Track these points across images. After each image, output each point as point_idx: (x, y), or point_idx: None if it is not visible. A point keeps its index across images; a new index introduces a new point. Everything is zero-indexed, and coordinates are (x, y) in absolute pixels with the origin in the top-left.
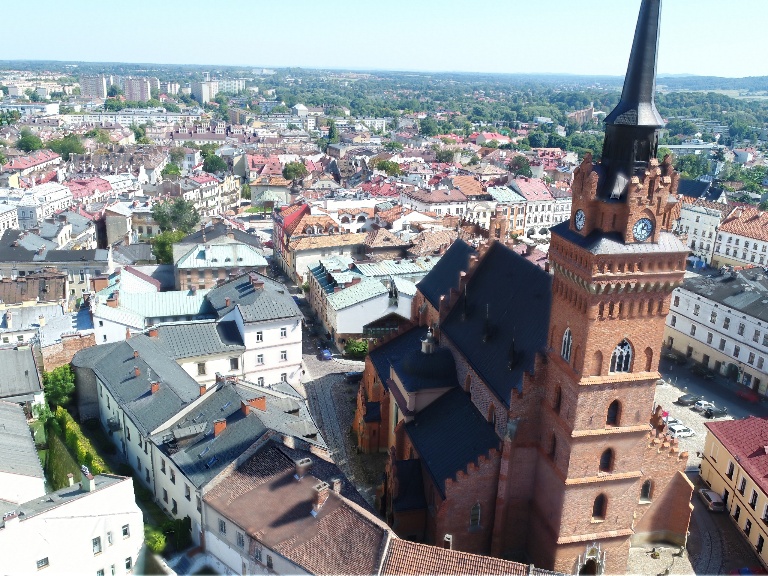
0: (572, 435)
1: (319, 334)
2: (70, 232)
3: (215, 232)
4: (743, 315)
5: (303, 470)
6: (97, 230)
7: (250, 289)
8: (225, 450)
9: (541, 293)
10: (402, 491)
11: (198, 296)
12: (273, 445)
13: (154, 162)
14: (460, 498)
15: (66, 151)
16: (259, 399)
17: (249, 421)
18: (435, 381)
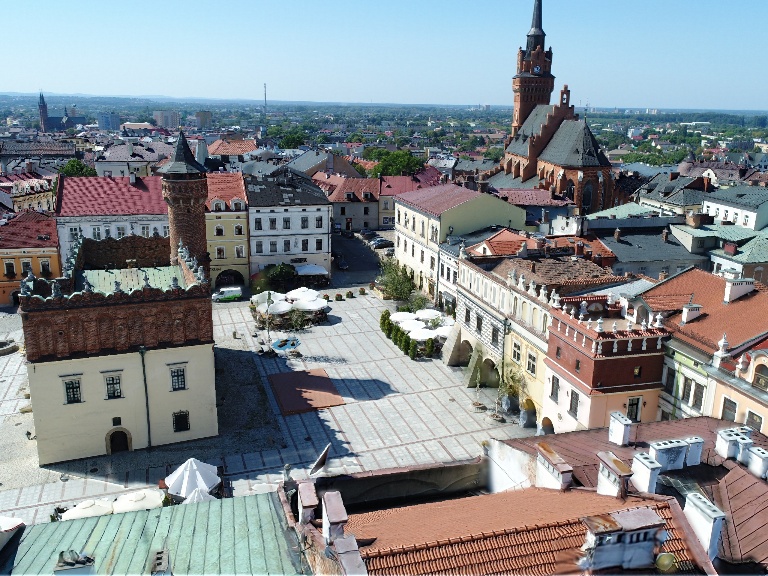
0: None
1: None
2: None
3: None
4: None
5: None
6: None
7: None
8: None
9: None
10: None
11: None
12: None
13: None
14: None
15: None
16: (673, 173)
17: None
18: None
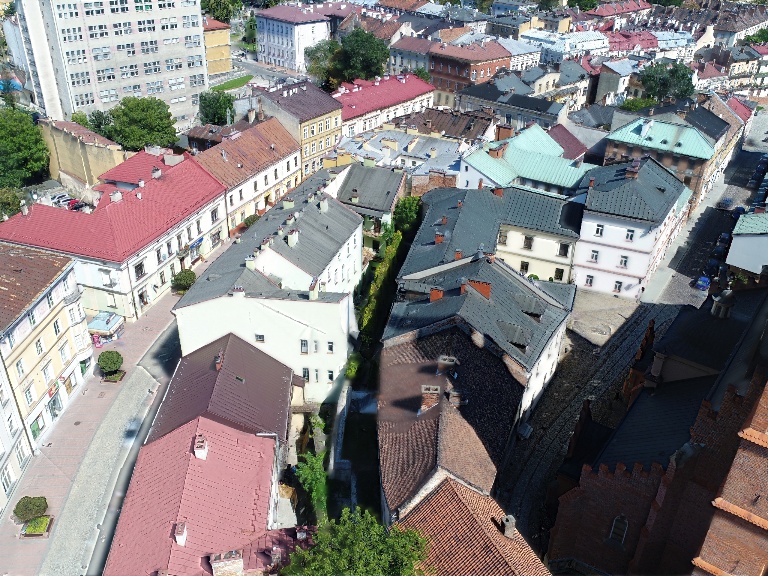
0: (713, 501)
1: (725, 258)
2: (556, 81)
3: (671, 107)
4: None
5: (443, 367)
6: (591, 85)
7: (624, 175)
8: (423, 317)
9: None
10: (580, 455)
11: (580, 169)
12: (453, 332)
13: (742, 24)
14: (598, 496)
15: (662, 2)
16: (483, 283)
17: (457, 300)
18: (702, 354)
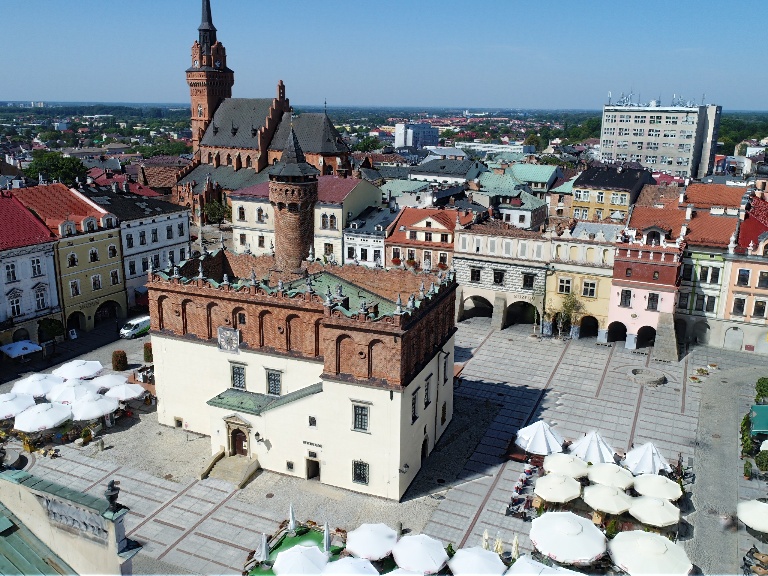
0: None
1: None
2: None
3: None
4: None
5: None
6: None
7: None
8: None
9: None
10: None
11: None
12: None
13: None
14: None
15: None
16: None
17: None
18: None
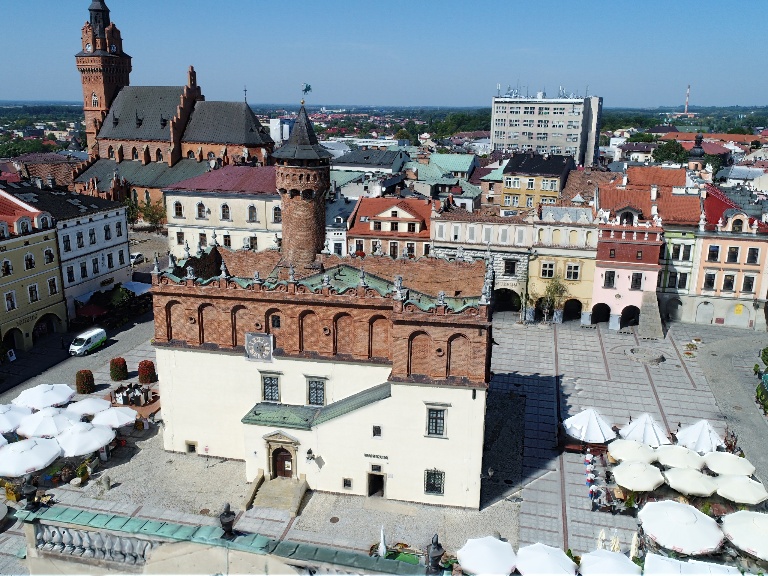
0: None
1: None
2: None
3: None
4: None
5: None
6: None
7: None
8: None
9: None
10: None
11: None
12: None
13: None
14: None
15: None
16: None
17: None
18: None
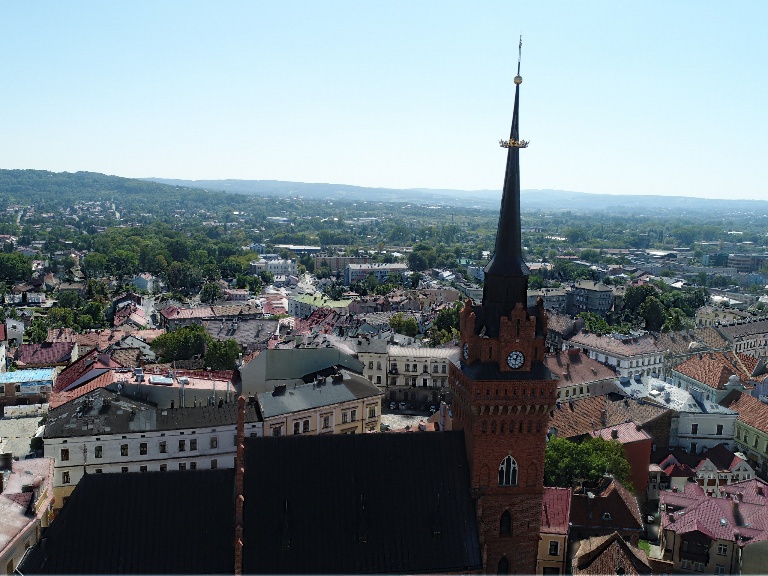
0: None
1: None
2: None
3: None
4: (162, 433)
5: None
6: None
7: None
8: None
9: (401, 454)
10: None
11: None
12: None
13: None
14: None
15: None
16: None
17: None
18: None
